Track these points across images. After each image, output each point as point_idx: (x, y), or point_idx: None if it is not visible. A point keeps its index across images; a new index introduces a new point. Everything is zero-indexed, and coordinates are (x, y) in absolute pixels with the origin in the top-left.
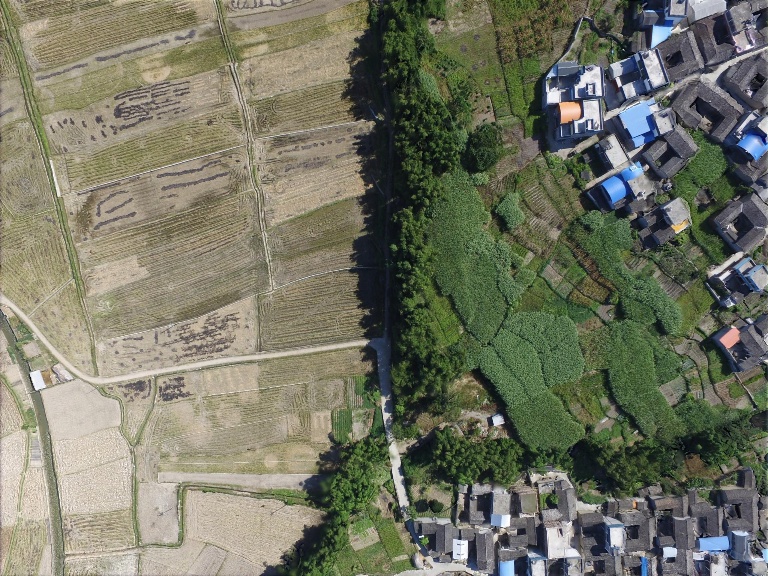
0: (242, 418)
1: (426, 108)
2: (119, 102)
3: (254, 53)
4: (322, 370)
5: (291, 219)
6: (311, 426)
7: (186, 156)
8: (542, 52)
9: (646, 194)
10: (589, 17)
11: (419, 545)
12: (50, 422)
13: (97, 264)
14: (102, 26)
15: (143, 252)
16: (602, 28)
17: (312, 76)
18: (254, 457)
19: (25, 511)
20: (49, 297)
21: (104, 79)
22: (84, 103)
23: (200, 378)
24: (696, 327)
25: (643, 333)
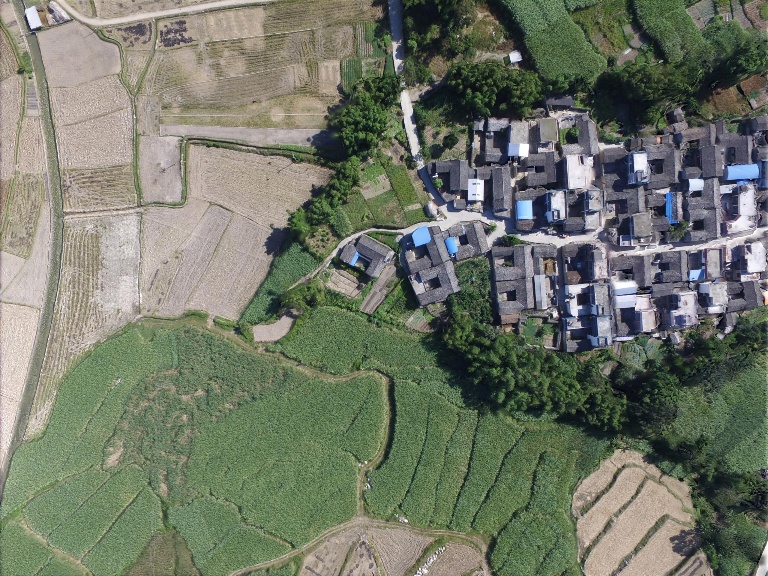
0: (247, 67)
1: None
2: None
3: None
4: (330, 16)
5: None
6: (319, 77)
7: None
8: None
9: None
10: None
11: (432, 194)
12: (47, 68)
13: None
14: None
15: None
16: None
17: None
18: (260, 110)
19: (22, 164)
20: None
21: None
22: None
23: (203, 22)
24: None
25: None
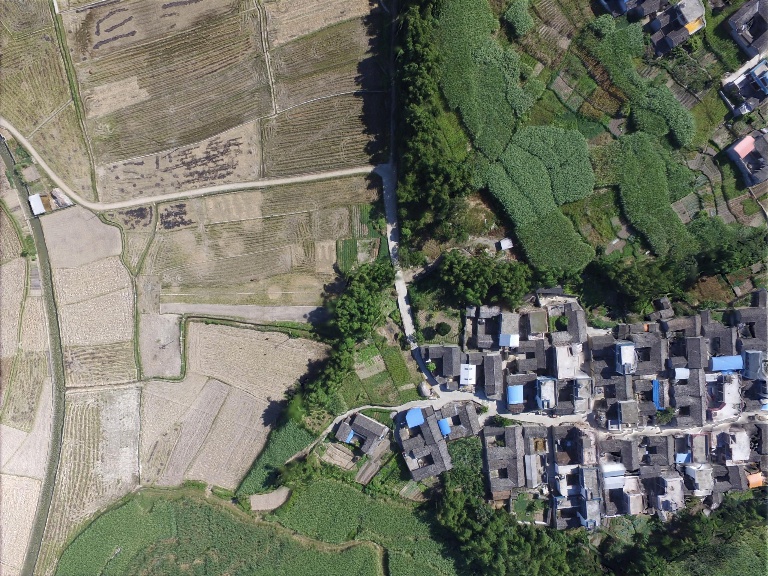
0: (245, 248)
1: None
2: None
3: None
4: (326, 198)
5: (294, 40)
6: (315, 256)
7: None
8: None
9: None
10: None
11: (426, 374)
12: (50, 250)
13: (96, 85)
14: None
15: (143, 73)
16: None
17: None
18: (257, 288)
19: (25, 342)
20: (48, 119)
21: None
22: None
23: (202, 205)
24: (710, 139)
25: (655, 146)
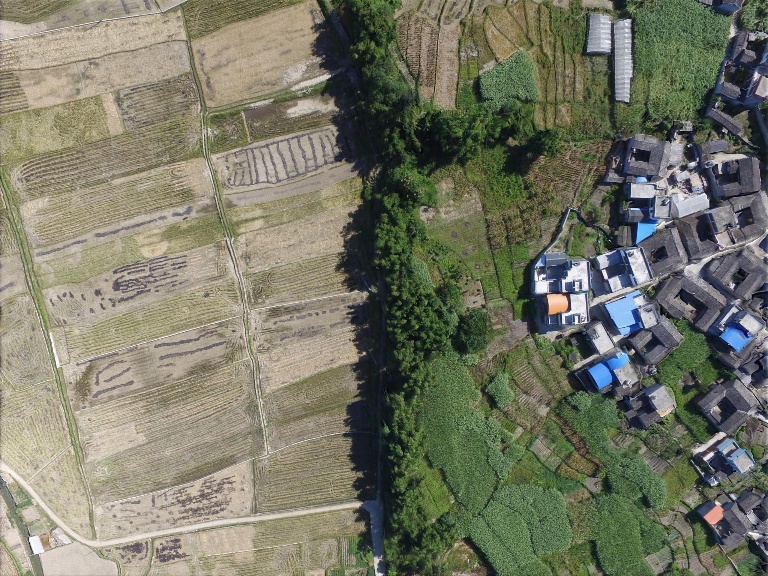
0: None
1: (417, 301)
2: (118, 276)
3: (250, 228)
4: (316, 530)
5: (286, 386)
6: None
7: (183, 327)
8: (531, 239)
9: (632, 382)
10: (576, 207)
11: None
12: None
13: (95, 431)
14: (101, 204)
15: (141, 419)
16: (589, 219)
17: (307, 249)
18: None
19: None
20: (48, 463)
21: (103, 254)
22: (83, 277)
23: (196, 540)
24: (681, 501)
25: (629, 506)
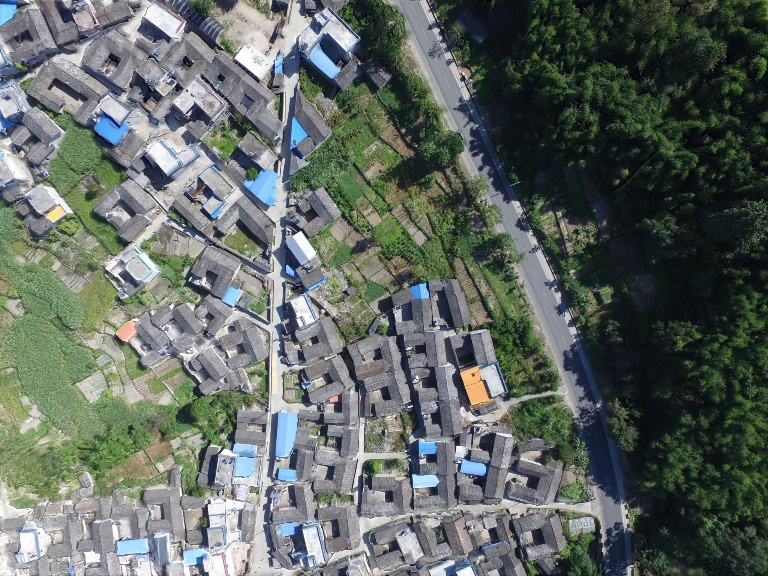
0: None
1: None
2: None
3: None
4: None
5: None
6: None
7: None
8: None
9: (5, 181)
10: None
11: None
12: None
13: None
14: None
15: None
16: None
17: None
18: None
19: None
20: None
21: None
22: None
23: None
24: (103, 320)
25: (48, 328)
